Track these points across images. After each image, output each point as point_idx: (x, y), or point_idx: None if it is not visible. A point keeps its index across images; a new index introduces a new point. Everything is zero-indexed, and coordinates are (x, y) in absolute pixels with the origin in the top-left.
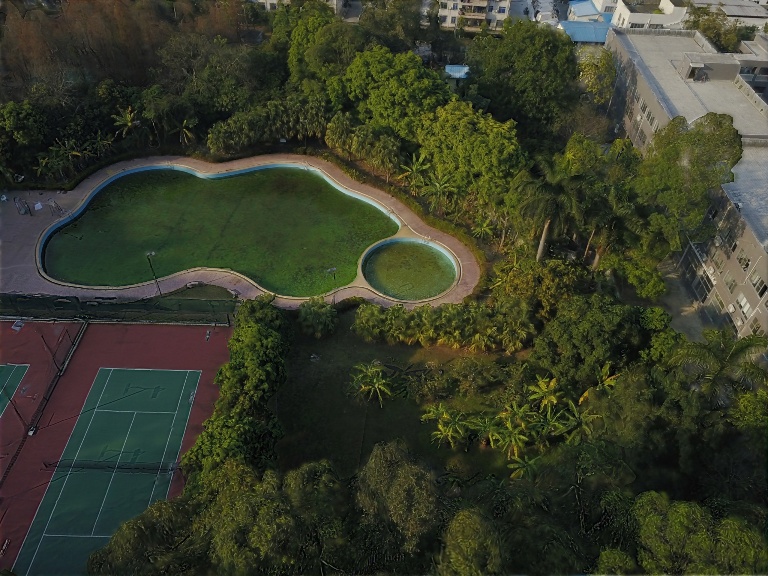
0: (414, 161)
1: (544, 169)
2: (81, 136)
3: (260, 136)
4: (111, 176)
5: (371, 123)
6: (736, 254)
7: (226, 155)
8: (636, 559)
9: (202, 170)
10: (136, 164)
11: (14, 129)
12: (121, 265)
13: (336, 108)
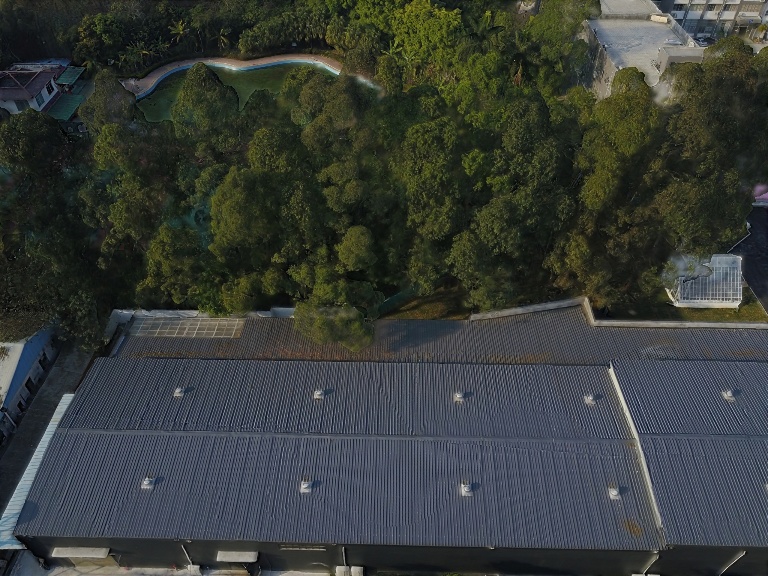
0: (390, 46)
1: (472, 25)
2: (148, 41)
3: (277, 39)
4: (170, 70)
5: (359, 21)
6: (603, 78)
7: (252, 55)
8: (459, 83)
9: (236, 65)
10: (187, 63)
11: (103, 32)
12: None
13: (333, 15)
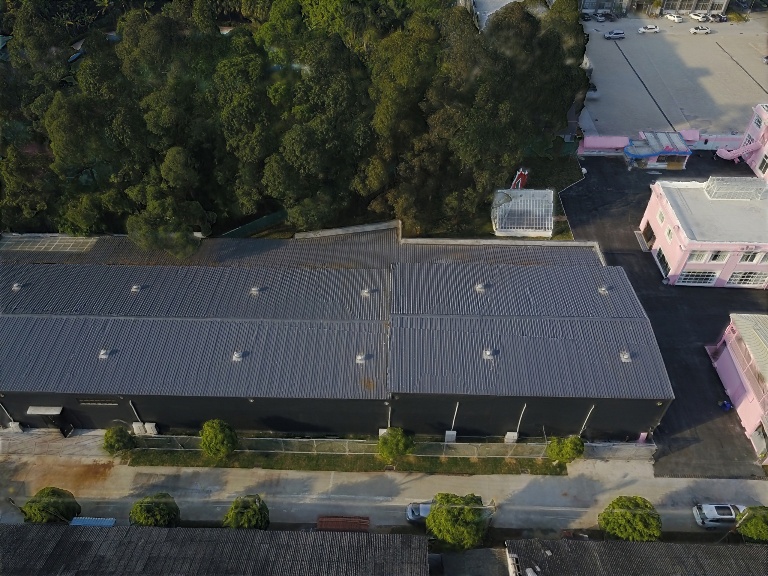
0: None
1: None
2: (74, 12)
3: None
4: None
5: None
6: None
7: None
8: None
9: None
10: None
11: None
12: None
13: None
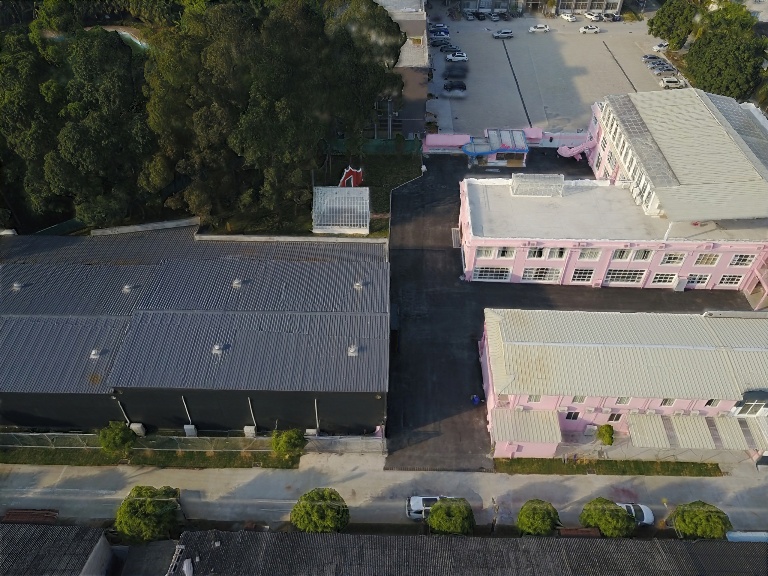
0: (180, 17)
1: None
2: None
3: (87, 11)
4: None
5: None
6: None
7: None
8: None
9: None
10: None
11: None
12: None
13: None
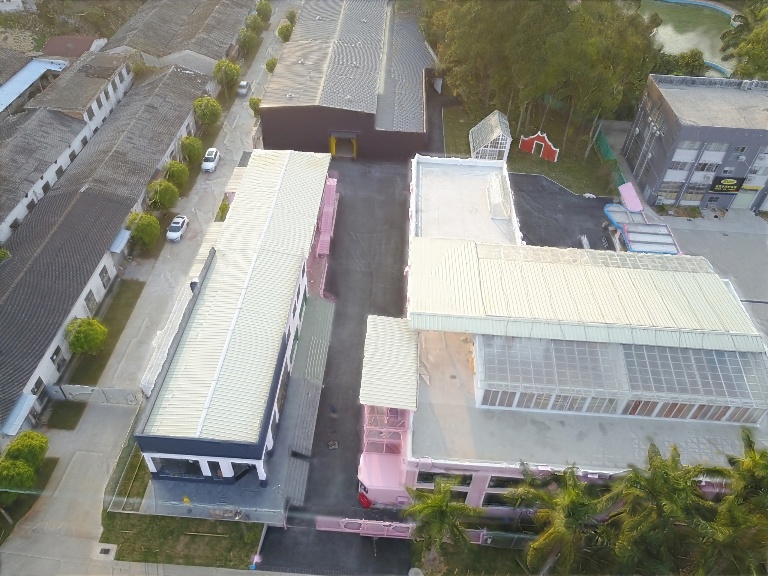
0: None
1: None
2: None
3: None
4: (707, 3)
5: None
6: None
7: None
8: None
9: None
10: (724, 6)
11: None
12: (642, 12)
13: None
